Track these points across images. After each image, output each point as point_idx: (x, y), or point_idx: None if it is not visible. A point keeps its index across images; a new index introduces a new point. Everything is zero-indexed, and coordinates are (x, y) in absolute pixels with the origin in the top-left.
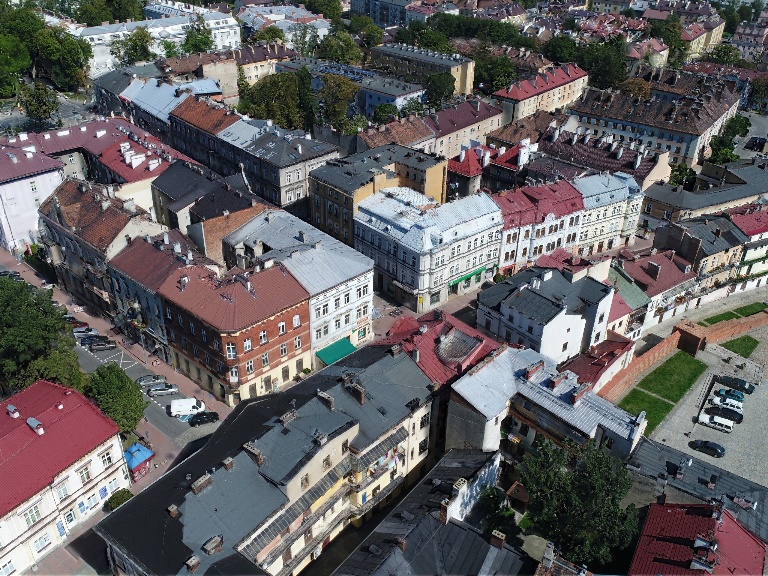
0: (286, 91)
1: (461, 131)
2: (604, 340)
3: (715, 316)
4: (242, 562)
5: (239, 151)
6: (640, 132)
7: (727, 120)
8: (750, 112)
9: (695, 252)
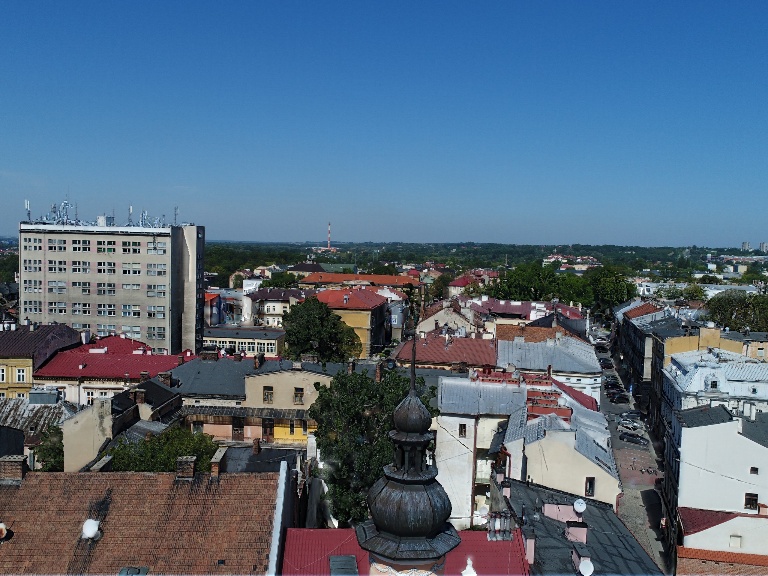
0: (760, 313)
1: None
2: None
3: None
4: (166, 394)
5: (636, 330)
6: None
7: None
8: None
9: None
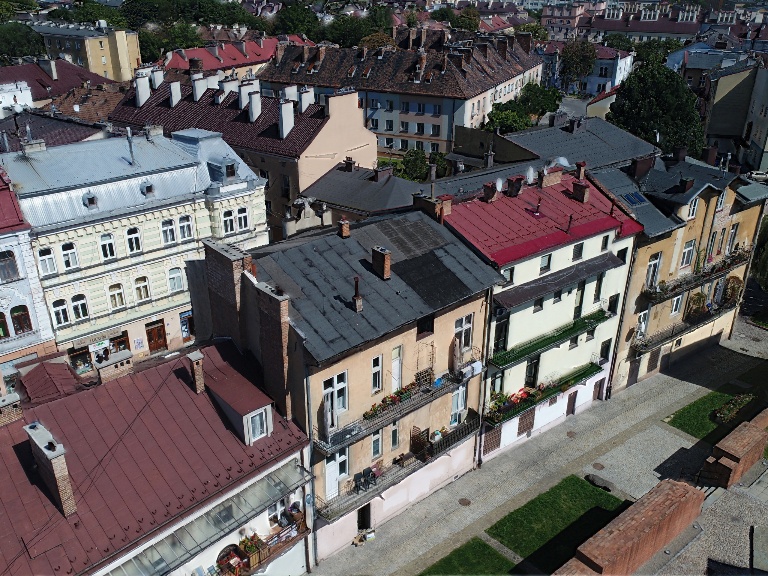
0: None
1: None
2: None
3: None
4: None
5: None
6: (371, 106)
7: (522, 88)
8: (566, 97)
9: (276, 350)
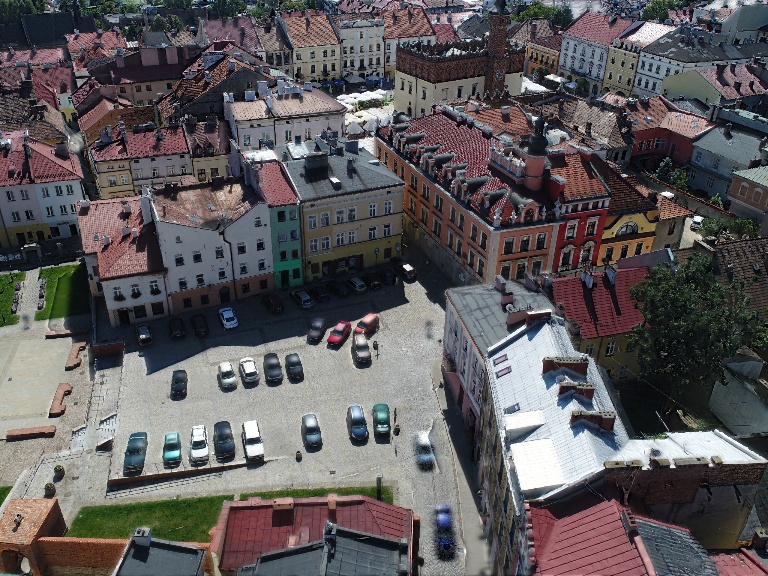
0: None
1: None
2: (223, 569)
3: None
4: None
5: None
6: None
7: None
8: None
9: None
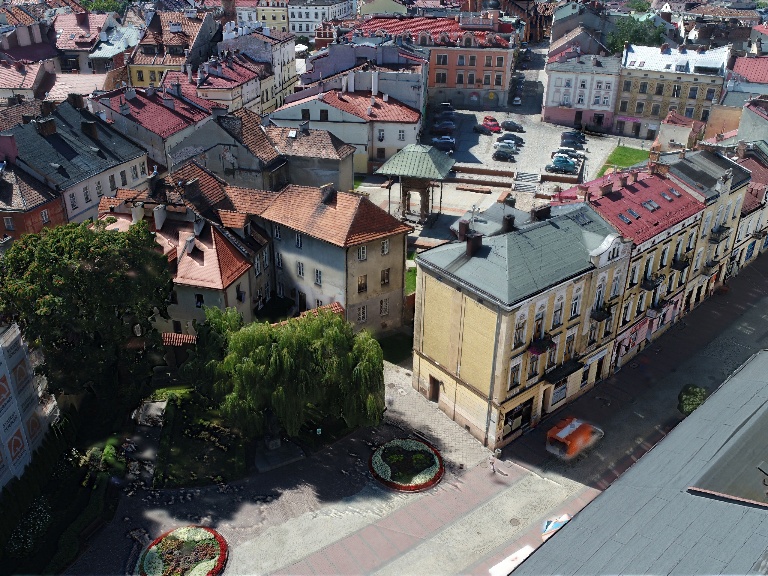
0: None
1: None
2: None
3: None
4: None
5: None
6: None
7: None
8: None
9: None
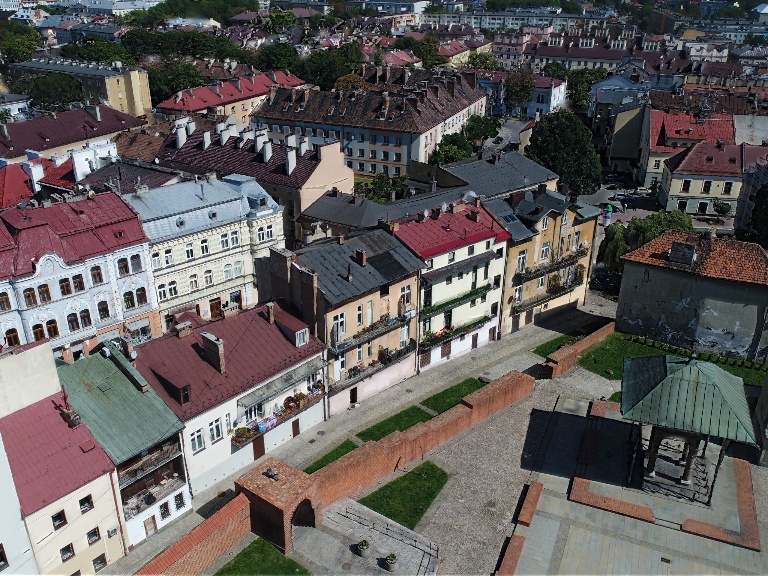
0: None
1: (61, 149)
2: None
3: (381, 422)
4: None
5: None
6: (347, 138)
7: (467, 119)
8: (510, 119)
9: (311, 301)
